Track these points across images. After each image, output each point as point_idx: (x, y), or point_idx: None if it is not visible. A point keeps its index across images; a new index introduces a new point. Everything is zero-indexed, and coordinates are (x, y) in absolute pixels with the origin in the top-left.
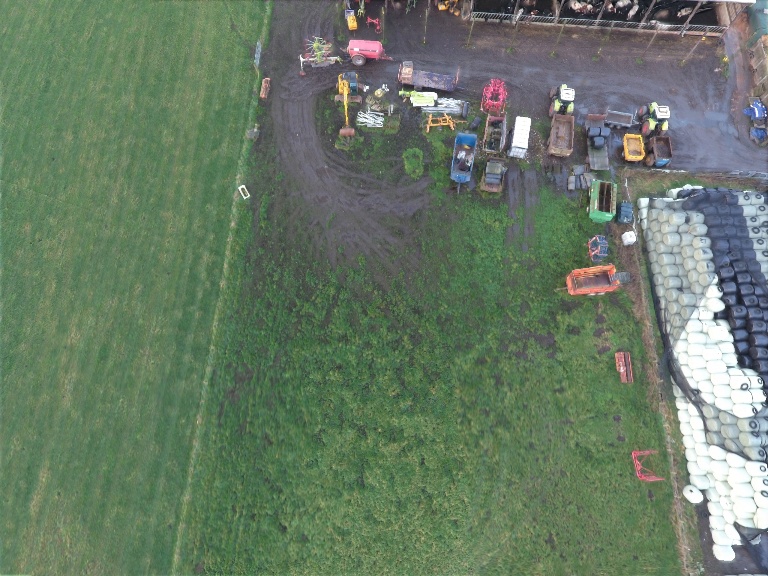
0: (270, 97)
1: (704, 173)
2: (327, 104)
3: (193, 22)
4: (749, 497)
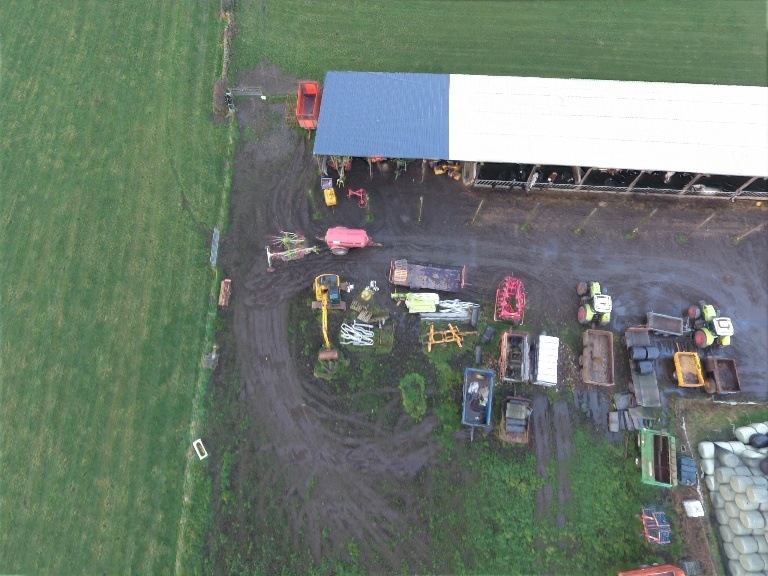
0: (231, 304)
1: None
2: (302, 312)
3: (136, 198)
4: None
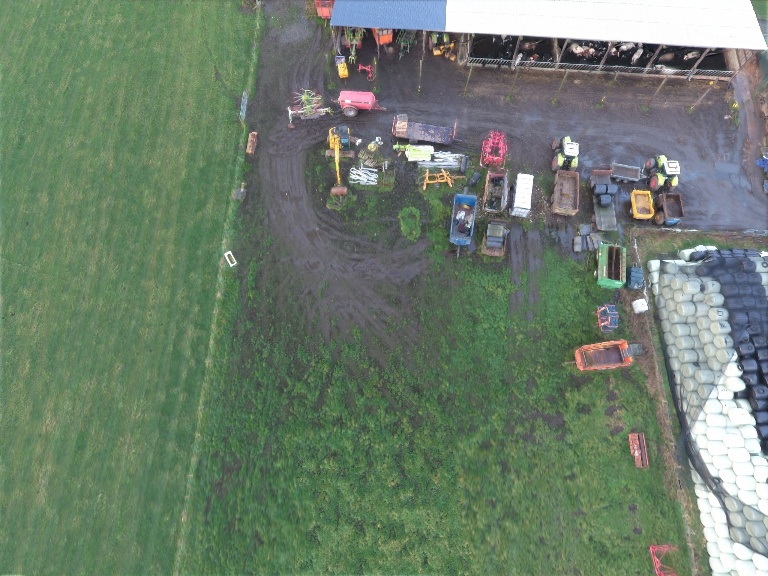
0: (257, 152)
1: (717, 231)
2: (318, 159)
3: (175, 71)
4: None
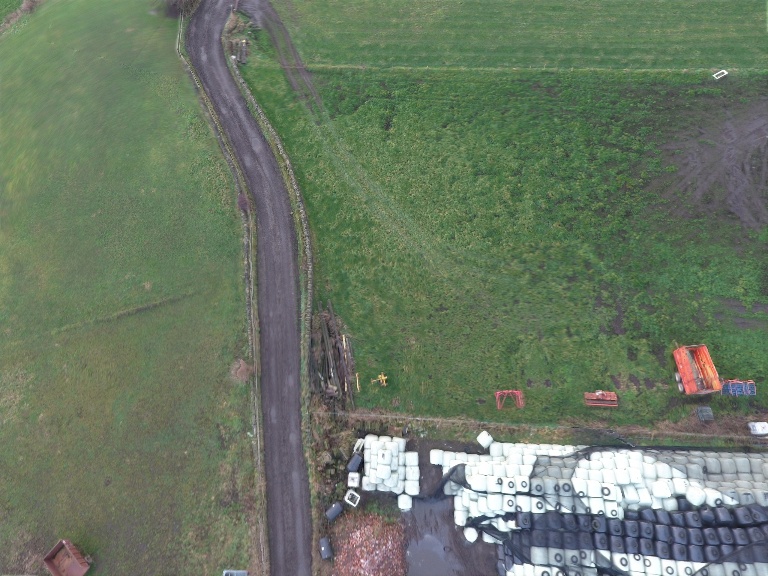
0: None
1: None
2: None
3: None
4: (493, 472)
